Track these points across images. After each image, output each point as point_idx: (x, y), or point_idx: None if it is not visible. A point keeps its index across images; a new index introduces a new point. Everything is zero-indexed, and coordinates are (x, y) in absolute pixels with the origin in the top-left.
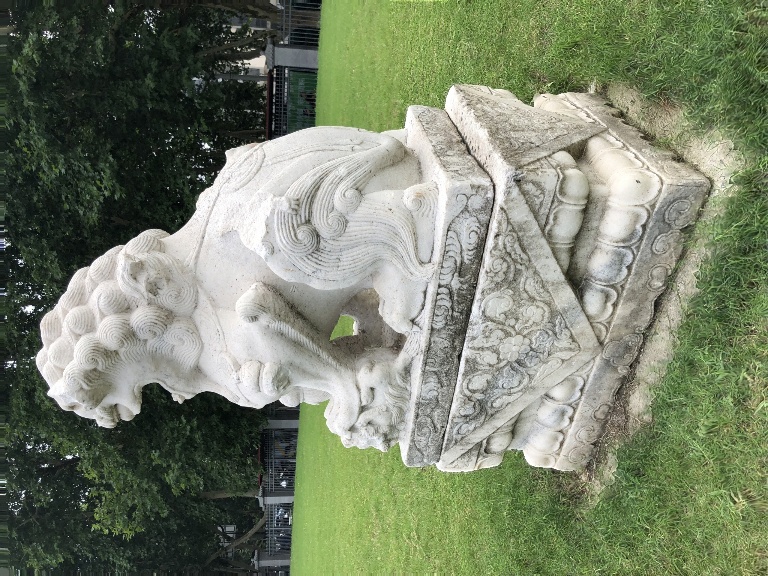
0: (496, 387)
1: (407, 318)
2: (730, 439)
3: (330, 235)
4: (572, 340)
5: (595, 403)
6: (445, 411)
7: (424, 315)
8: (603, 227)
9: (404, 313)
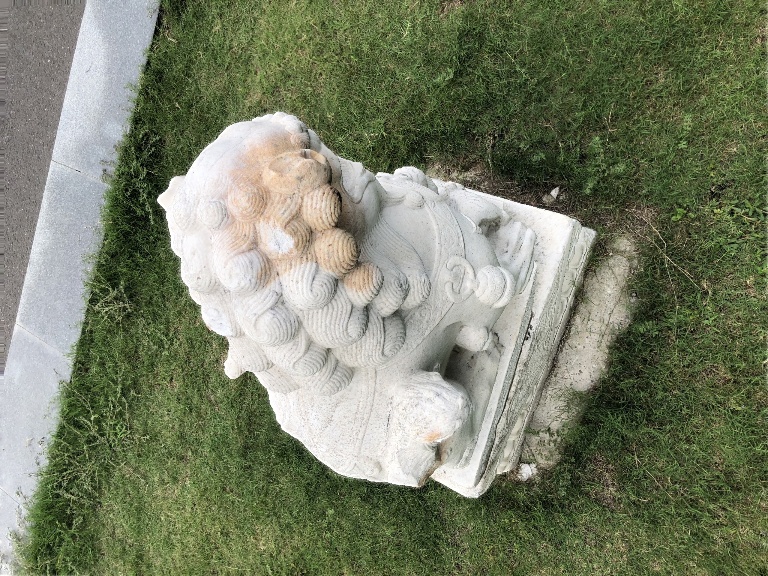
0: None
1: None
2: None
3: None
4: None
5: None
6: None
7: None
8: None
9: None
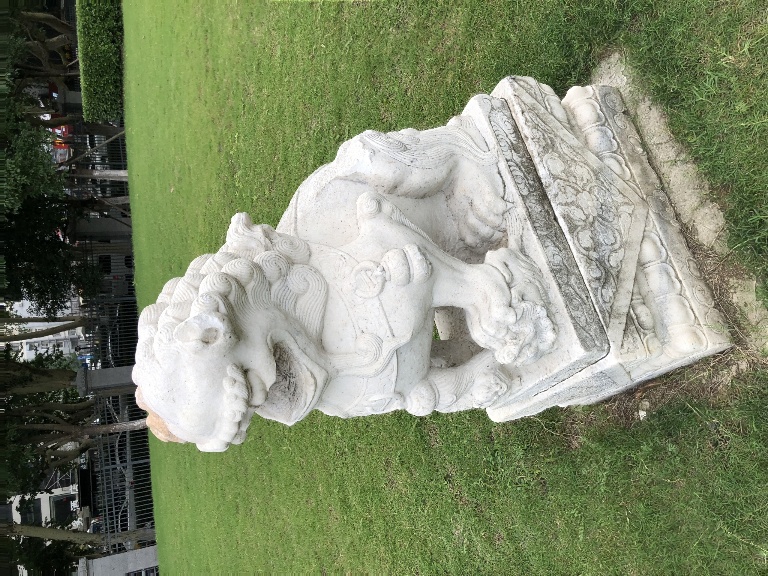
0: (601, 244)
1: (498, 195)
2: (759, 90)
3: (411, 141)
4: (622, 195)
5: (682, 258)
6: (578, 278)
7: (509, 189)
8: (580, 120)
9: (493, 191)
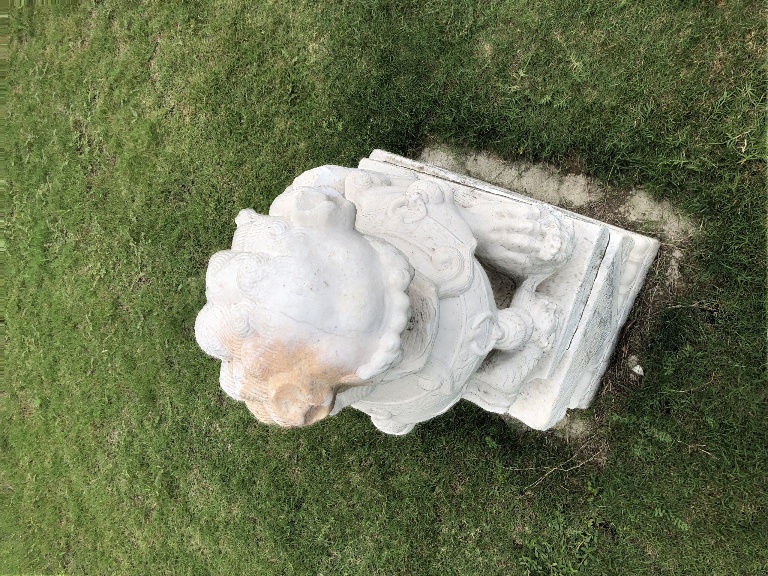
0: None
1: None
2: None
3: None
4: None
5: None
6: None
7: None
8: None
9: None
